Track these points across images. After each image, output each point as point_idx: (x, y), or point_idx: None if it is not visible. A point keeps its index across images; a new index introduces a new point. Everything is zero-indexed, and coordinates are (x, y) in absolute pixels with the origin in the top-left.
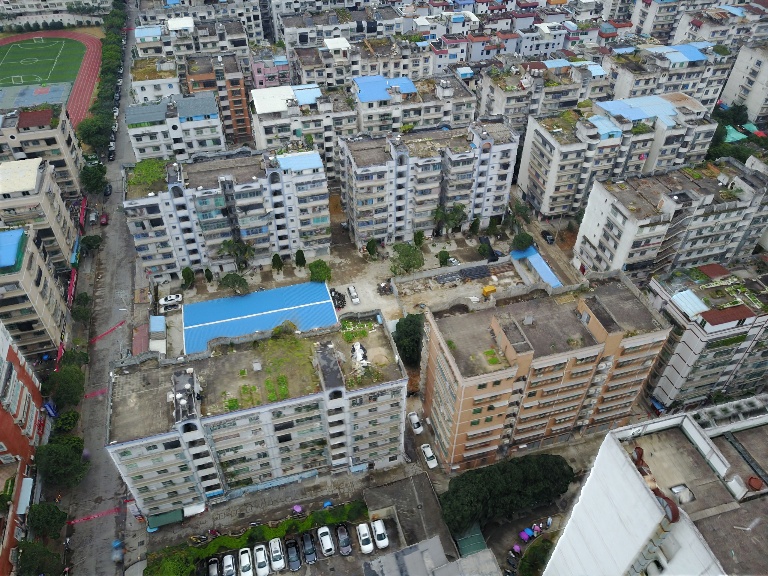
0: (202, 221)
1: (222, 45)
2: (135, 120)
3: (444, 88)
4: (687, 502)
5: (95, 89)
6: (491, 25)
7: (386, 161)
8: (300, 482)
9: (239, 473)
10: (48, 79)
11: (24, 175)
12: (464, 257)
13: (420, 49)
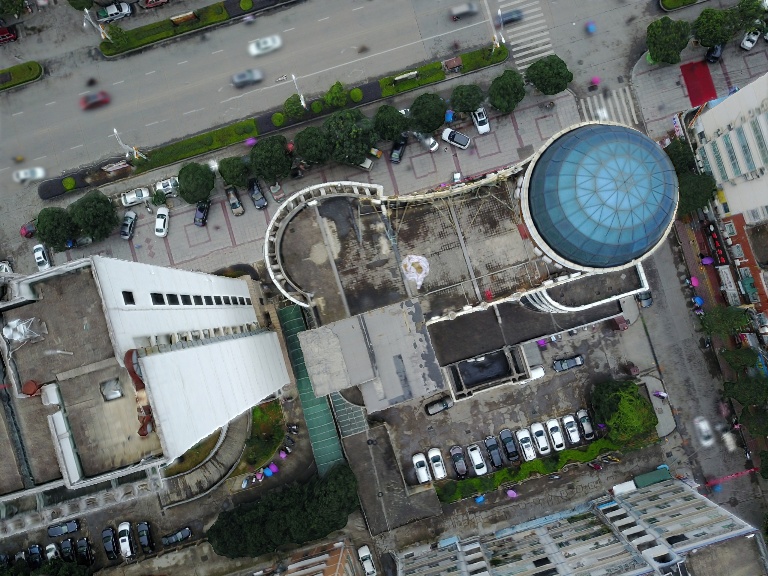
0: None
1: None
2: None
3: None
4: (110, 381)
5: None
6: None
7: None
8: None
9: (586, 526)
10: None
11: None
12: None
13: None
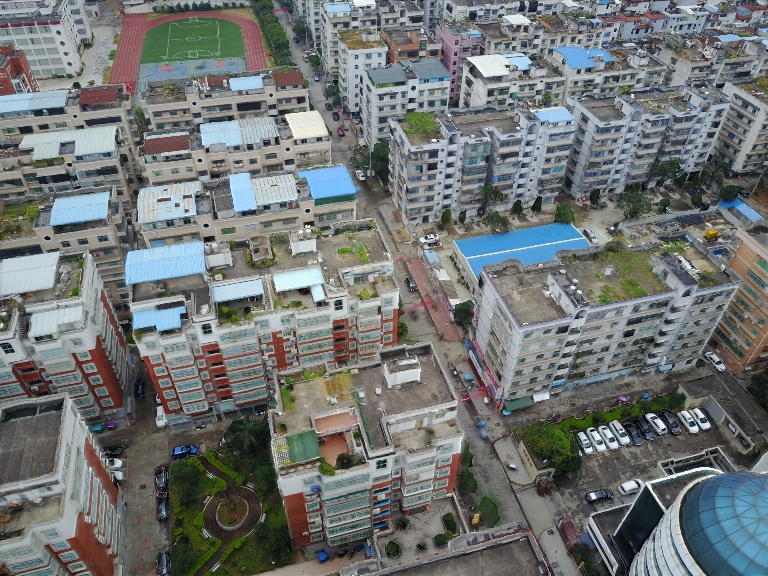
0: (467, 167)
1: (401, 21)
2: (382, 81)
3: (641, 57)
4: None
5: (268, 63)
6: (631, 7)
7: (623, 116)
8: (613, 380)
9: (580, 366)
10: (220, 54)
11: (314, 124)
12: (674, 207)
13: (594, 25)
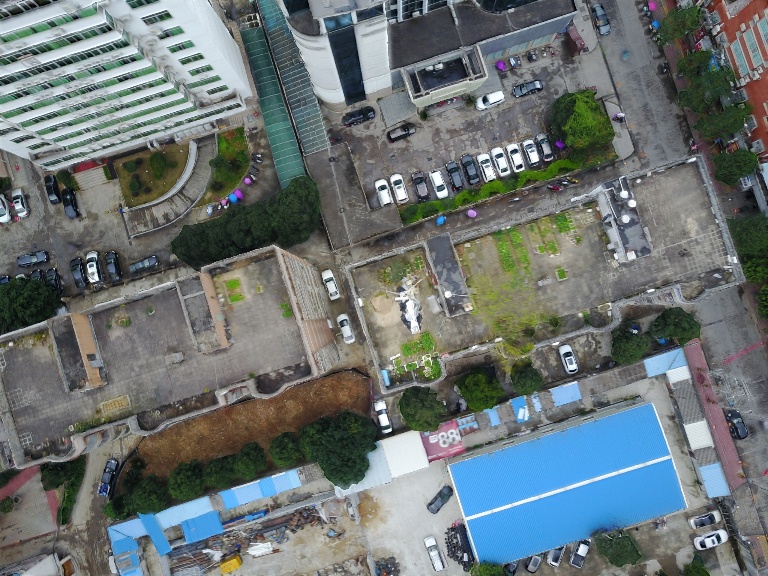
0: None
1: None
2: None
3: None
4: None
5: None
6: None
7: None
8: None
9: None
10: None
11: None
12: None
13: None
